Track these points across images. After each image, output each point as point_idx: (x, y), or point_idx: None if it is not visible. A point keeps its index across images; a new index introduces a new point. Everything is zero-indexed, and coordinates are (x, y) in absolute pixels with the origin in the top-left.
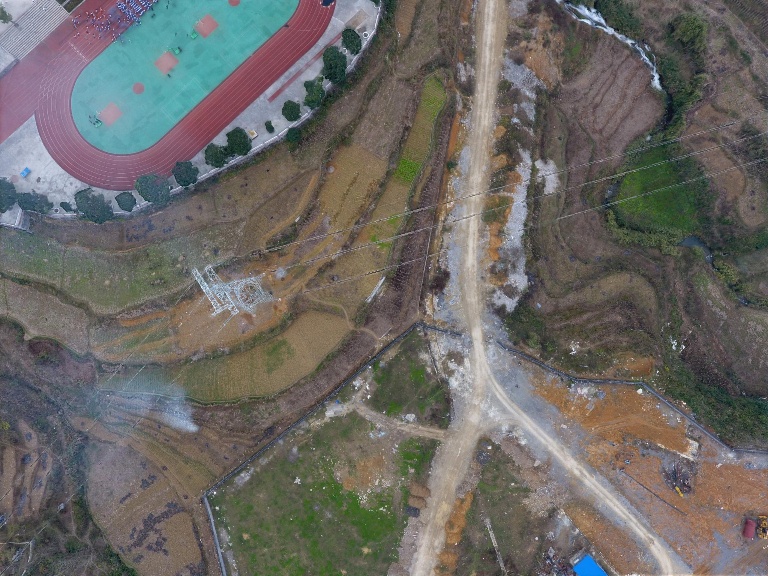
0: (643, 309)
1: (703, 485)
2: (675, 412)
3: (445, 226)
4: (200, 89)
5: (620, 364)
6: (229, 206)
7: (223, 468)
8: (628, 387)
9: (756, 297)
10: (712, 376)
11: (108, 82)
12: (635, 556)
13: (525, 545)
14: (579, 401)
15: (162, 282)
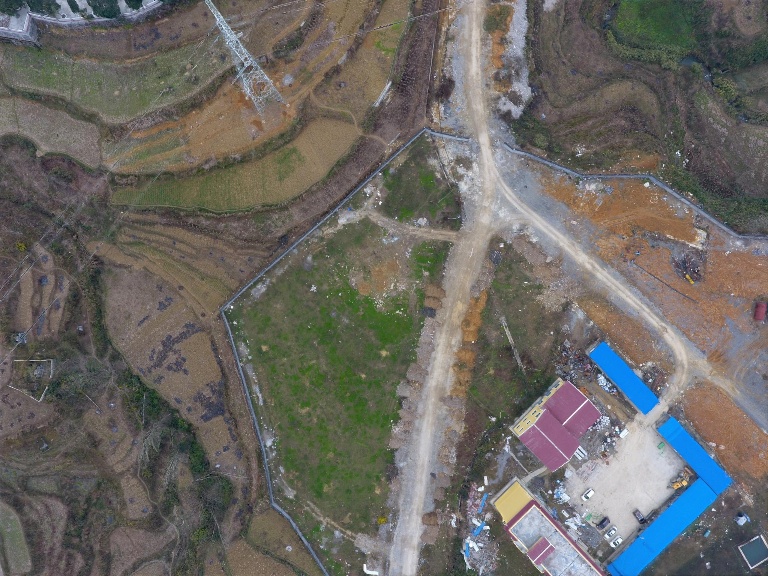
0: (646, 115)
1: (713, 272)
2: (682, 203)
3: (448, 35)
4: None
5: (626, 162)
6: (234, 12)
7: (239, 281)
8: (635, 181)
9: (756, 113)
10: (716, 186)
11: None
12: (649, 345)
13: (541, 340)
14: (588, 197)
15: (171, 90)
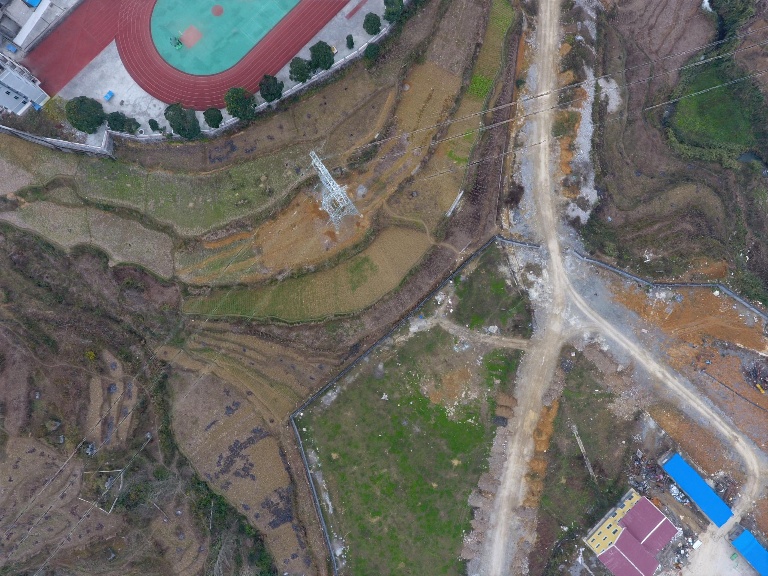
0: (711, 218)
1: None
2: (752, 312)
3: (517, 142)
4: (278, 9)
5: (695, 269)
6: (309, 125)
7: (309, 388)
8: (705, 290)
9: None
10: None
11: (186, 5)
12: (721, 454)
13: (612, 449)
14: (658, 305)
15: (246, 202)
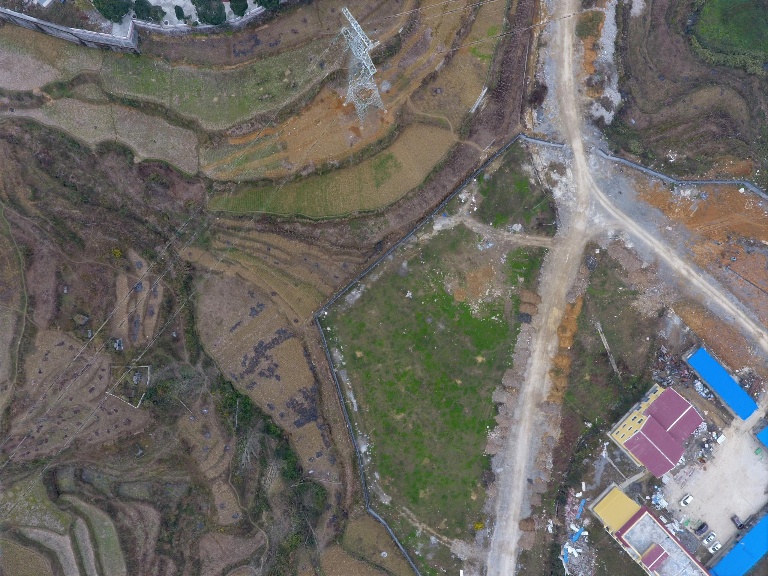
0: (735, 120)
1: None
2: None
3: (540, 41)
4: None
5: (720, 167)
6: (333, 19)
7: (334, 287)
8: (730, 187)
9: None
10: None
11: None
12: (745, 350)
13: (637, 346)
14: (683, 203)
15: (270, 97)
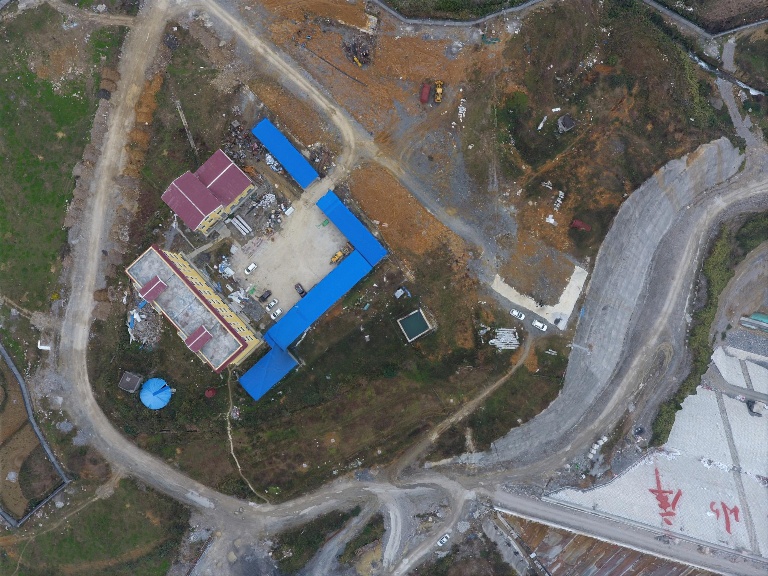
0: None
1: (382, 56)
2: None
3: None
4: None
5: None
6: None
7: None
8: None
9: None
10: None
11: None
12: (318, 126)
13: (213, 122)
14: None
15: None
